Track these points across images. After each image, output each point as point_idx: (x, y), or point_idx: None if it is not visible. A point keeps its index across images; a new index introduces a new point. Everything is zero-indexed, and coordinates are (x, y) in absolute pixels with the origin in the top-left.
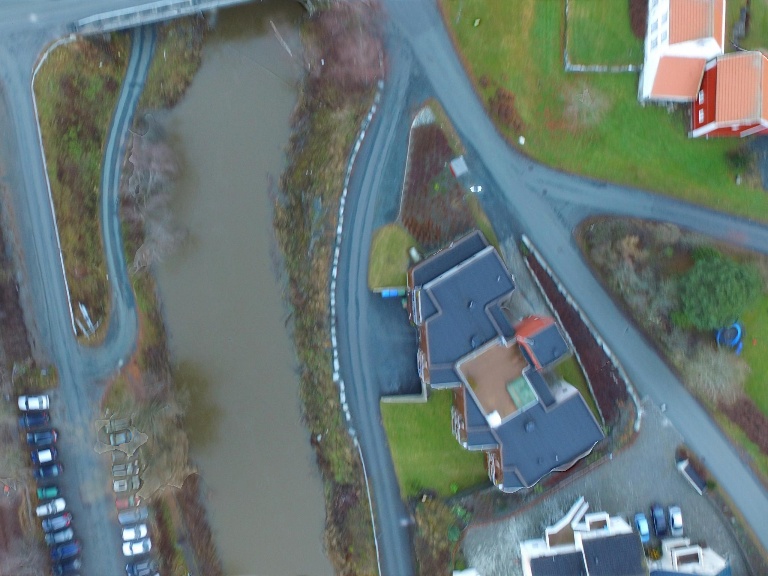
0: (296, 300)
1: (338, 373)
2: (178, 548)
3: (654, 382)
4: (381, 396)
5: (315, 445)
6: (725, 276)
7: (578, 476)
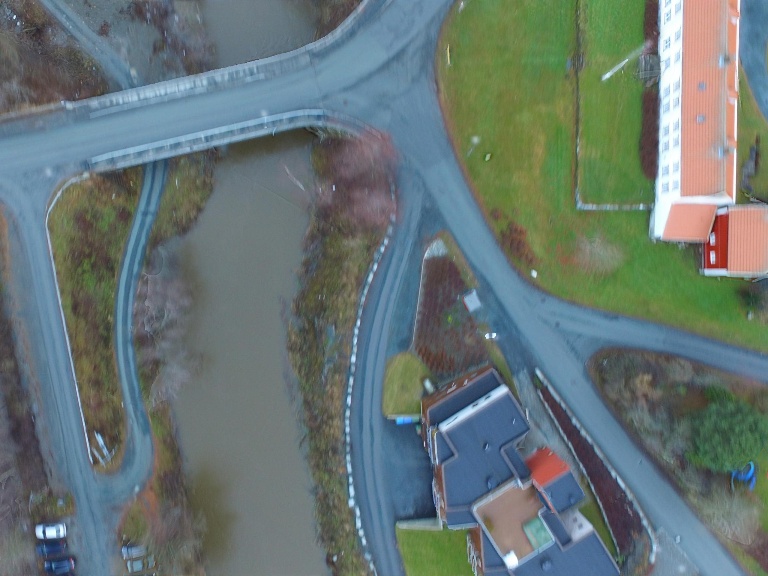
0: (310, 422)
1: (353, 499)
2: None
3: (668, 514)
4: (396, 521)
5: (331, 565)
6: (739, 428)
7: None
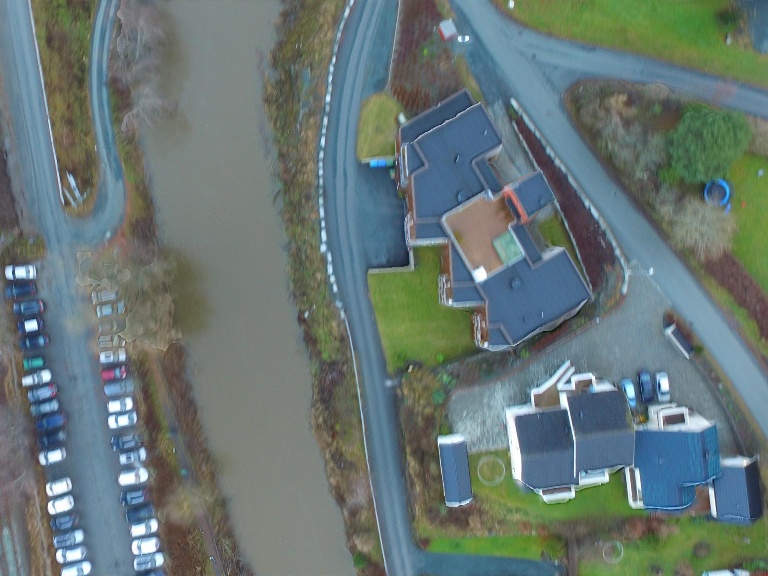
0: (284, 175)
1: (325, 244)
2: (164, 423)
3: (642, 245)
4: (368, 268)
5: (302, 322)
6: (712, 118)
7: (565, 341)
